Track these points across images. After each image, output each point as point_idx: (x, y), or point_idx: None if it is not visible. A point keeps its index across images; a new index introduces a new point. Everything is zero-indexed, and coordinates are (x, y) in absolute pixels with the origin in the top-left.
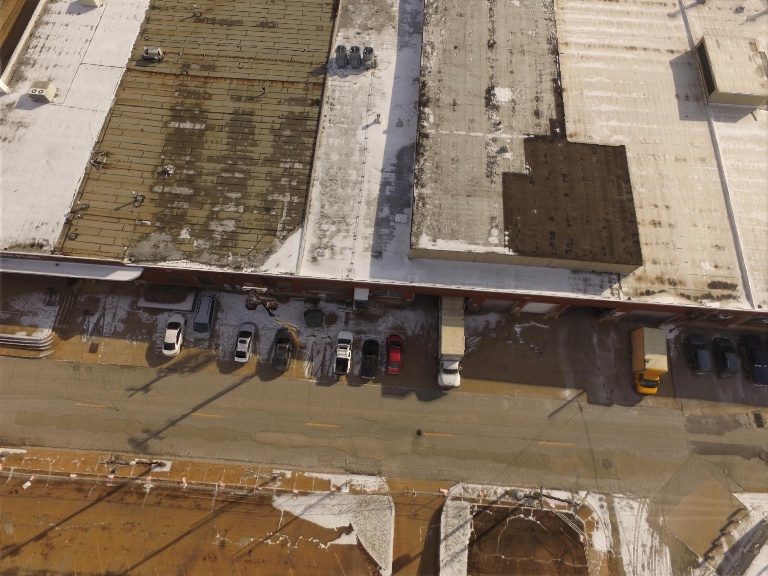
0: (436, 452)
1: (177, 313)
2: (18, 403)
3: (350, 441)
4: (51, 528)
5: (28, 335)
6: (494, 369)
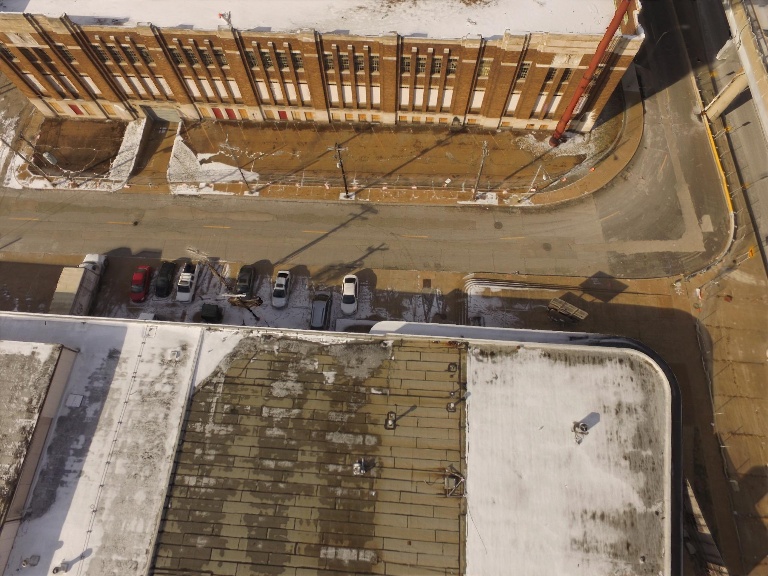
0: (126, 211)
1: (350, 315)
2: (479, 236)
3: (195, 217)
4: (419, 156)
5: (488, 289)
6: (53, 275)
